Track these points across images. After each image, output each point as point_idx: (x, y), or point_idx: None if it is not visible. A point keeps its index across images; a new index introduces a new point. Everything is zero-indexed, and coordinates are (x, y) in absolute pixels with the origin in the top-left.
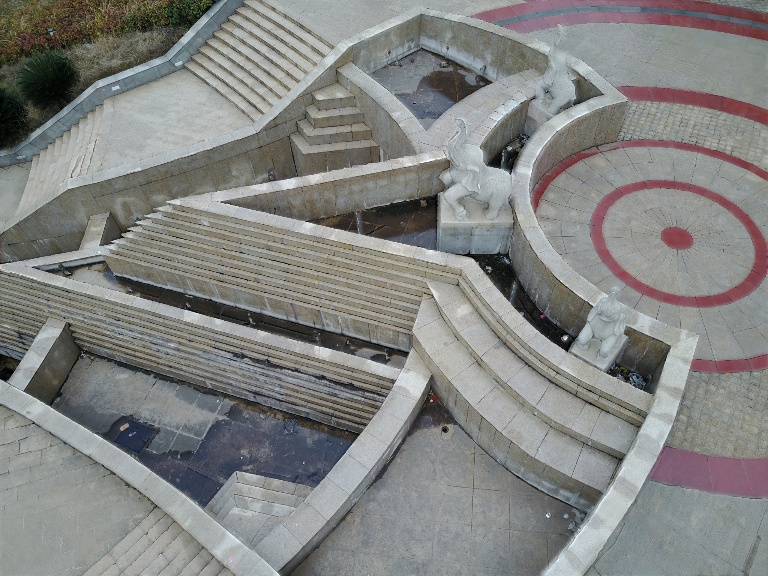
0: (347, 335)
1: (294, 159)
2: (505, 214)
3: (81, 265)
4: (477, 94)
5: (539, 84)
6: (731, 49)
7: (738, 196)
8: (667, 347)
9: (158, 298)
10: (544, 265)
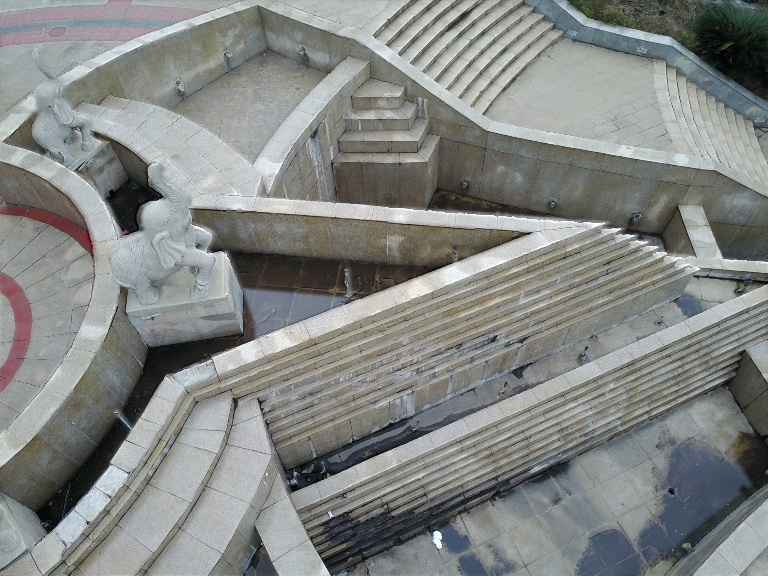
0: None
1: None
2: None
3: None
4: None
5: None
6: None
7: None
8: None
9: None
10: None
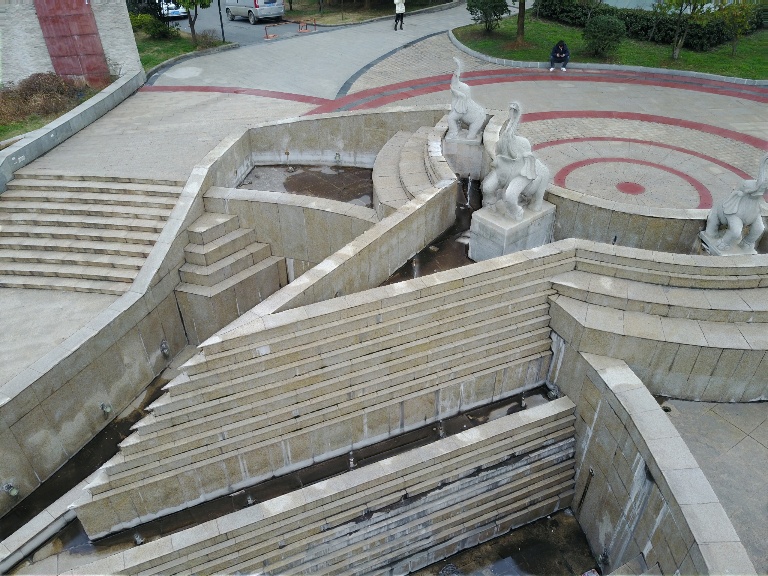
0: (464, 410)
1: (182, 319)
2: (542, 204)
3: (13, 566)
4: (381, 158)
5: (451, 118)
6: (499, 91)
7: (624, 154)
8: (767, 219)
9: (193, 524)
10: (628, 213)
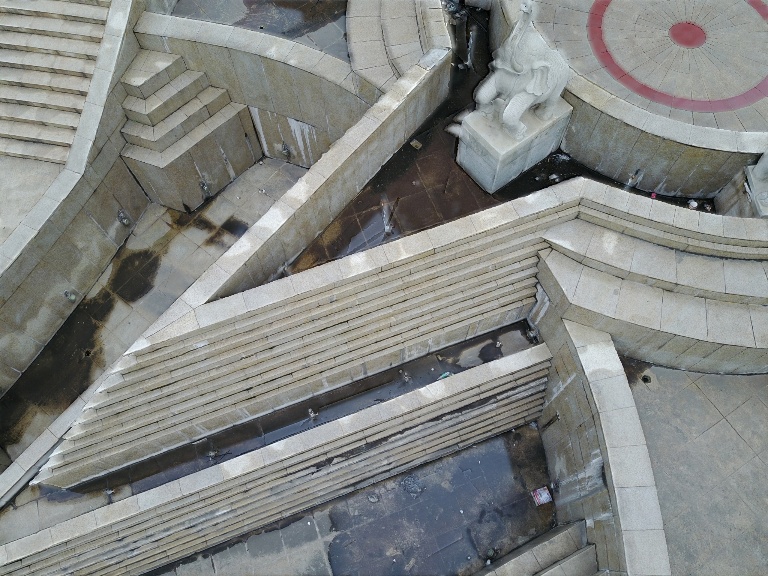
0: (434, 351)
1: (138, 181)
2: (556, 103)
3: None
4: None
5: None
6: None
7: None
8: None
9: (159, 473)
10: (661, 138)
